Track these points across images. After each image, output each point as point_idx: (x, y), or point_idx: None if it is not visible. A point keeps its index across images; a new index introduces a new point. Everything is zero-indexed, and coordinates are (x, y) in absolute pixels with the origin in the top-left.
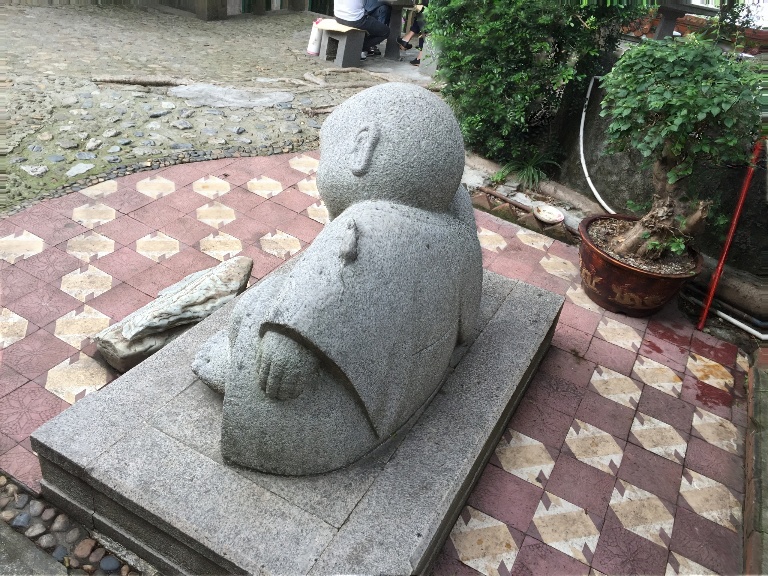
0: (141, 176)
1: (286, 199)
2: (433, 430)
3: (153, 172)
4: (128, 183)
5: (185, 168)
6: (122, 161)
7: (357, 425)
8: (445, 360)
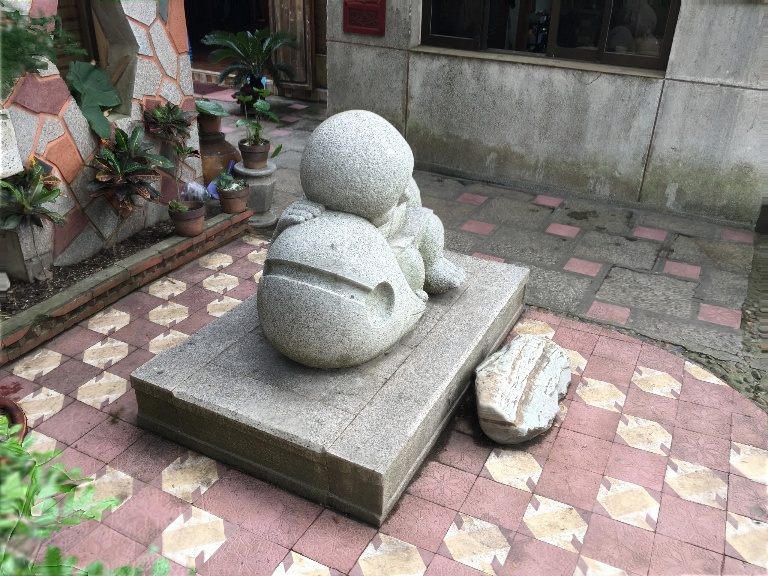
0: None
1: None
2: None
3: None
4: None
5: None
6: None
7: None
8: None
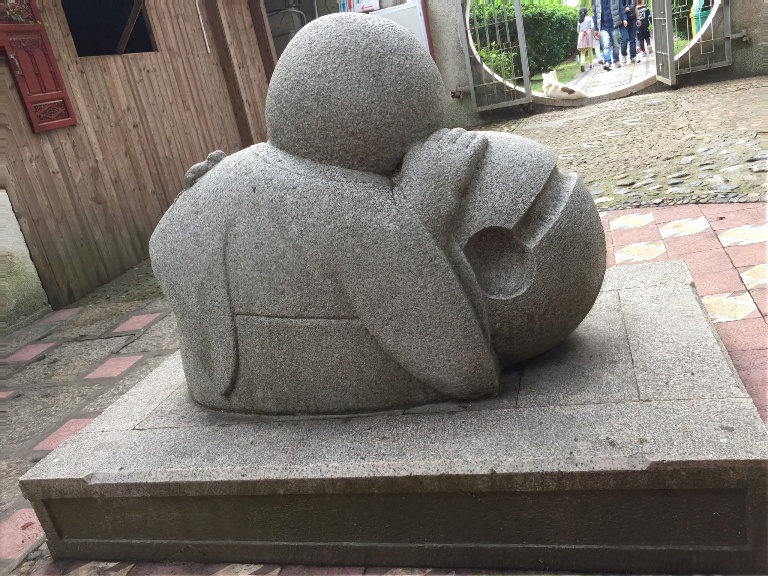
0: (635, 211)
1: (748, 251)
2: (274, 434)
3: (652, 209)
4: (614, 215)
5: (690, 208)
6: (641, 197)
7: (199, 362)
8: (327, 366)
